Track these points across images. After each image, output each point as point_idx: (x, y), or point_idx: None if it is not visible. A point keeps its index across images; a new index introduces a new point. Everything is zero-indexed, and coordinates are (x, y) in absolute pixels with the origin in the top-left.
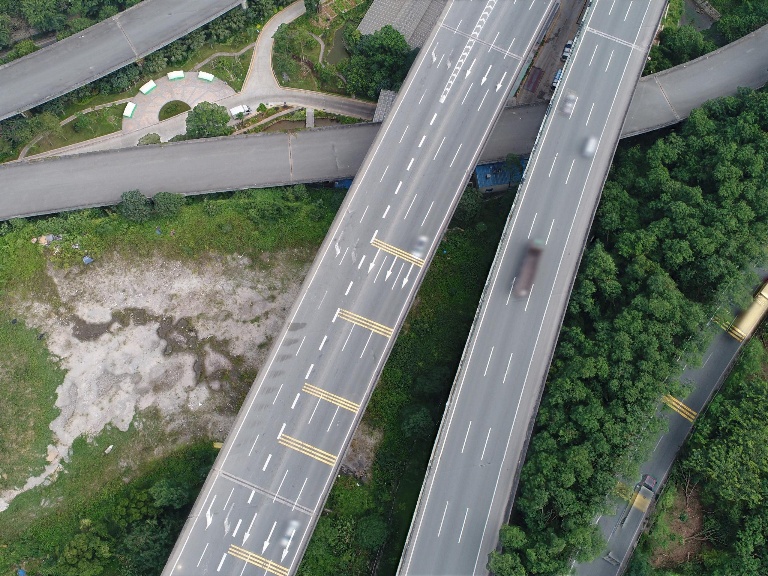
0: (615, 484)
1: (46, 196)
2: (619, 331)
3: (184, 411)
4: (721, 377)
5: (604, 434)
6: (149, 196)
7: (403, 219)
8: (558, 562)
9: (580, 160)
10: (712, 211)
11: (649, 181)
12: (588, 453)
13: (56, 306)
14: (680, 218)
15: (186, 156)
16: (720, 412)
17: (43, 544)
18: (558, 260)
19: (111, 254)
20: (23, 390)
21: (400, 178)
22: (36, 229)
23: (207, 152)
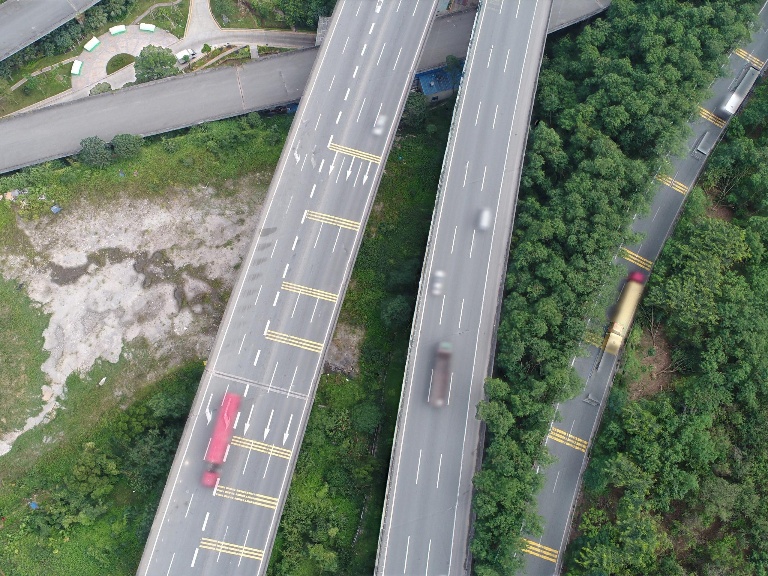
0: (584, 326)
1: (6, 155)
2: (570, 193)
3: (171, 337)
4: (670, 228)
5: (568, 284)
6: (108, 142)
7: (355, 122)
8: (542, 404)
9: (515, 49)
10: (642, 77)
11: (581, 62)
12: (556, 303)
13: (31, 256)
14: (614, 88)
15: (139, 100)
16: (672, 252)
17: (51, 476)
18: (506, 141)
19: (78, 201)
20: (10, 338)
21: (347, 85)
22: (1, 186)
23: (159, 94)
